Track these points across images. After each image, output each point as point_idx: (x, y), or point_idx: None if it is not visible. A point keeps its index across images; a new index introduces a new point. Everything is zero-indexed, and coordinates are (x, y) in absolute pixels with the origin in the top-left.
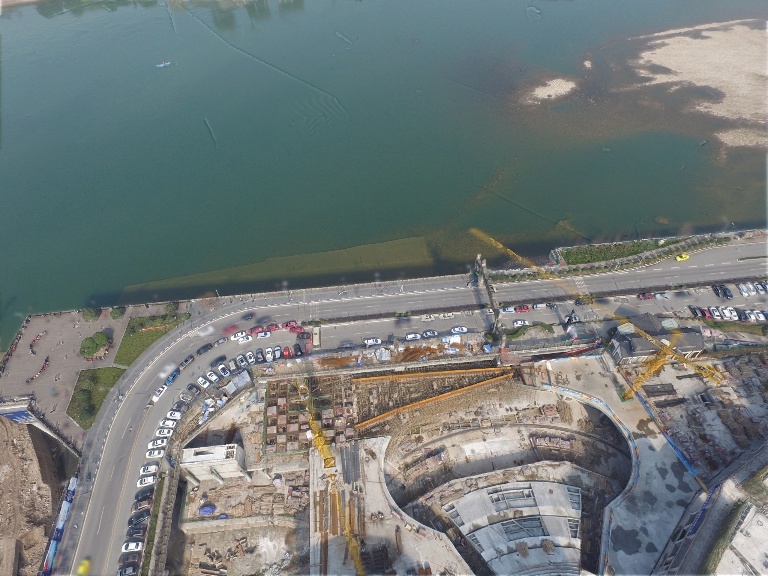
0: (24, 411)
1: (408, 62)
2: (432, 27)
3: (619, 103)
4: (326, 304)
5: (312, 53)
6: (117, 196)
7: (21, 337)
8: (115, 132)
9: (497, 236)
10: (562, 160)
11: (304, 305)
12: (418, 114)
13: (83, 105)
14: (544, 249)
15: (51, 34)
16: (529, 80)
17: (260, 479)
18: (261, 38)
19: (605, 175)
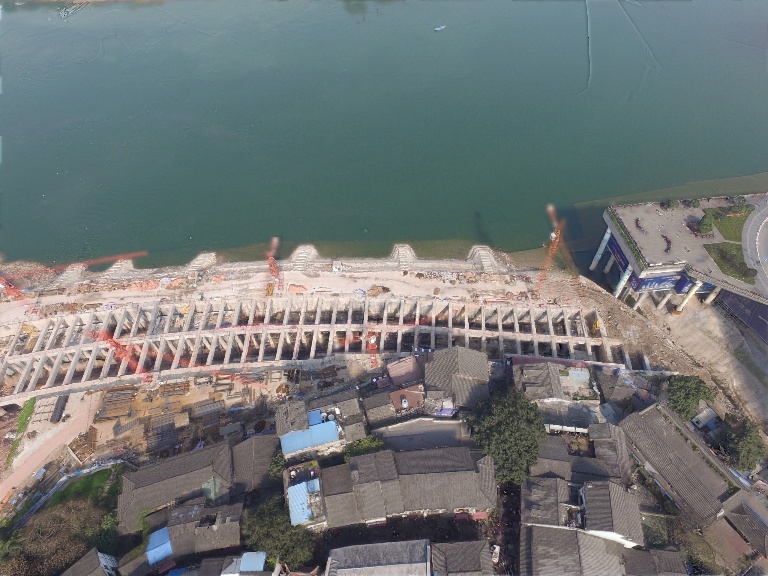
0: (663, 277)
1: (668, 27)
2: None
3: None
4: None
5: (569, 19)
6: None
7: None
8: (449, 83)
9: None
10: None
11: None
12: (706, 71)
13: (390, 62)
14: None
15: (302, 4)
16: None
17: None
18: (523, 5)
19: None
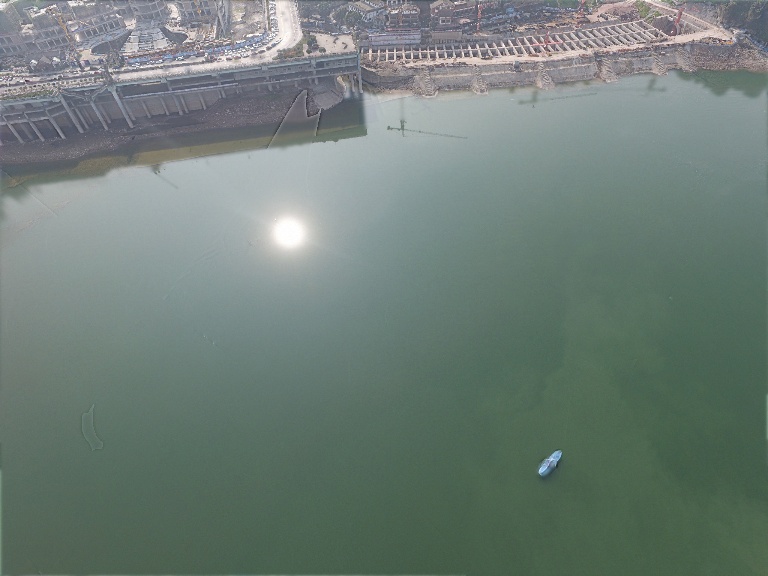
0: None
1: None
2: None
3: None
4: (201, 68)
5: None
6: None
7: None
8: (485, 256)
9: (77, 171)
10: None
11: None
12: (52, 365)
13: (604, 325)
14: (49, 166)
15: None
16: None
17: None
18: None
19: None
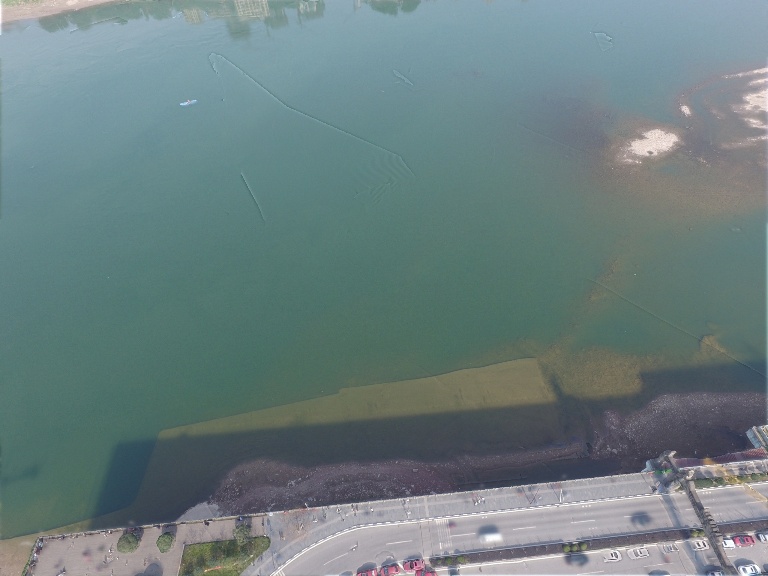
0: None
1: (471, 102)
2: (498, 60)
3: (736, 164)
4: (459, 522)
5: (358, 88)
6: (143, 288)
7: None
8: (136, 195)
9: (629, 359)
10: (686, 244)
11: (428, 523)
12: (491, 170)
13: (96, 155)
14: (694, 381)
15: (57, 59)
16: (621, 130)
17: None
18: (300, 71)
19: (741, 265)
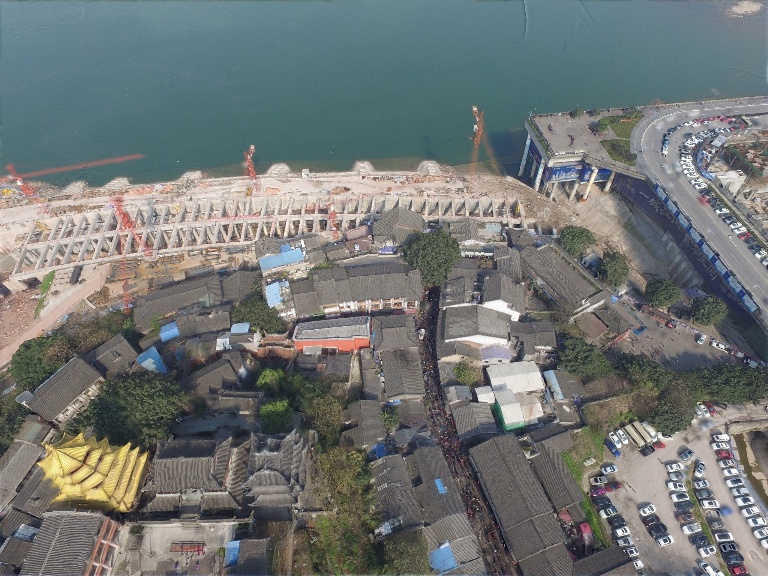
0: (568, 166)
1: None
2: None
3: None
4: (732, 109)
5: None
6: (450, 78)
7: (538, 126)
8: (407, 38)
9: None
10: None
11: (717, 109)
12: (635, 29)
13: (355, 22)
14: None
15: None
16: (722, 2)
17: (742, 201)
18: None
19: None
